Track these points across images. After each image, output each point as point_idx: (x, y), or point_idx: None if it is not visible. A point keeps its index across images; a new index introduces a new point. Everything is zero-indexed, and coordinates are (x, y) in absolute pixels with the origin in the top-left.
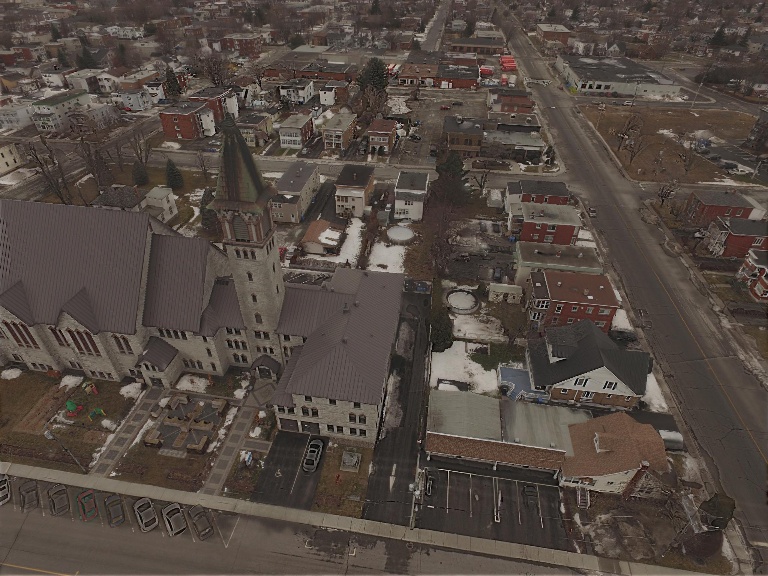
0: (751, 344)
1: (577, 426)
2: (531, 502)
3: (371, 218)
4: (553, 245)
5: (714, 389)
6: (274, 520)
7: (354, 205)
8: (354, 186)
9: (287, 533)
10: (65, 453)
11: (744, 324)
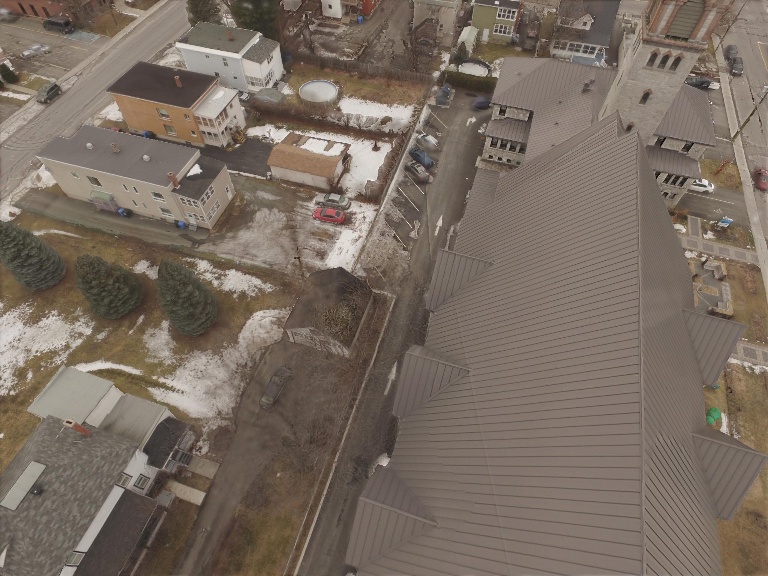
0: None
1: None
2: (704, 79)
3: (278, 105)
4: None
5: None
6: (760, 214)
7: (234, 114)
8: (207, 89)
9: (767, 206)
10: (767, 406)
11: None
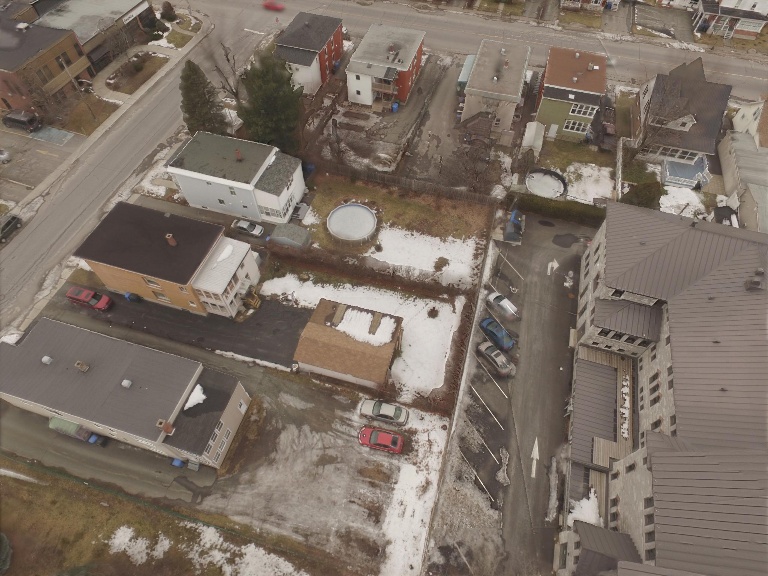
0: (583, 27)
1: (763, 140)
2: None
3: (303, 253)
4: (478, 64)
5: (645, 64)
6: None
7: (246, 273)
8: (211, 249)
9: None
10: None
11: (557, 19)
